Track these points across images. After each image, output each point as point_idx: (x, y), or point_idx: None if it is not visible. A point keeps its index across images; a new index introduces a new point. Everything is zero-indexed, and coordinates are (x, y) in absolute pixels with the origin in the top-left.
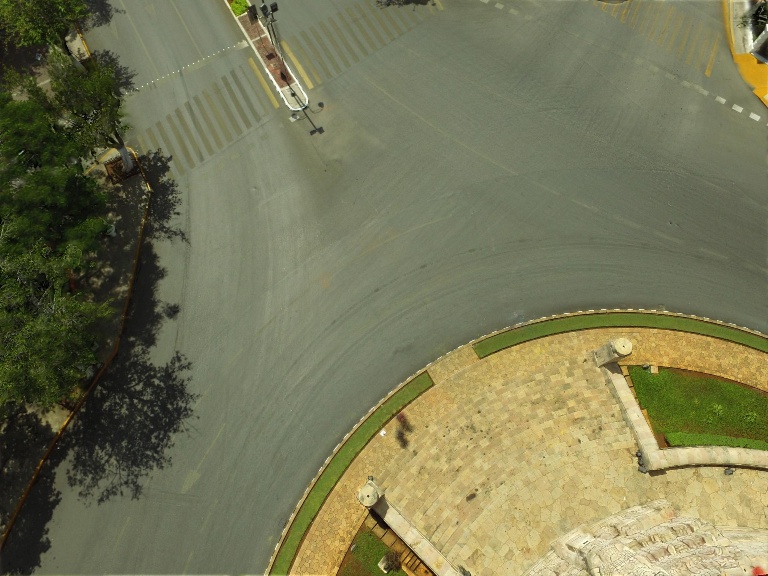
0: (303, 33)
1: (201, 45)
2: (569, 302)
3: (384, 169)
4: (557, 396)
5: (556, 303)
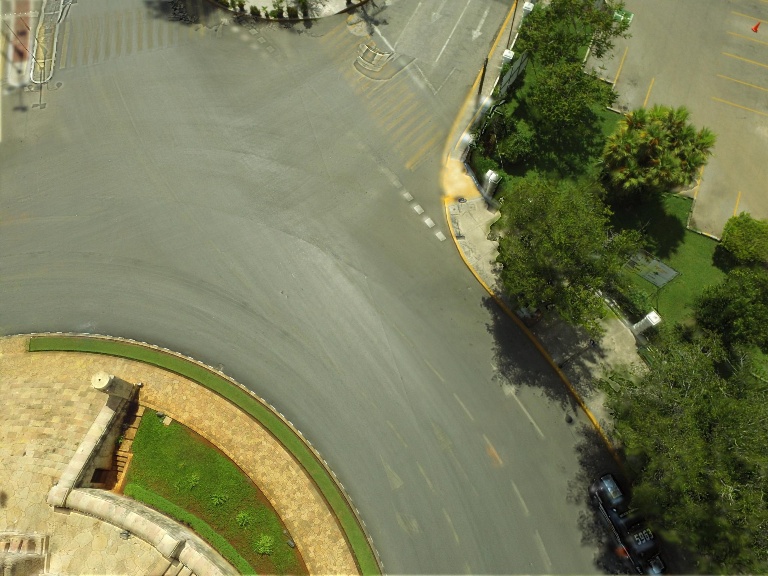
0: (90, 20)
1: (0, 4)
2: (142, 331)
3: (70, 157)
4: (54, 408)
5: (131, 327)
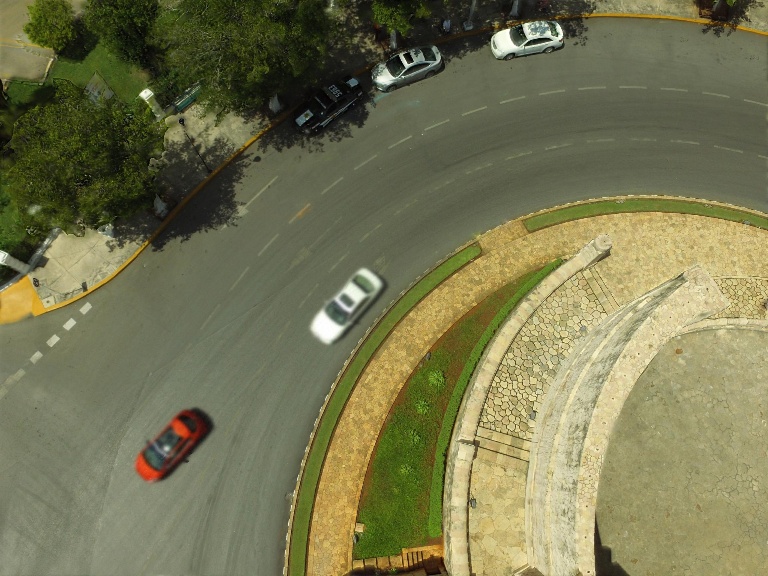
0: None
1: None
2: None
3: None
4: None
5: None
